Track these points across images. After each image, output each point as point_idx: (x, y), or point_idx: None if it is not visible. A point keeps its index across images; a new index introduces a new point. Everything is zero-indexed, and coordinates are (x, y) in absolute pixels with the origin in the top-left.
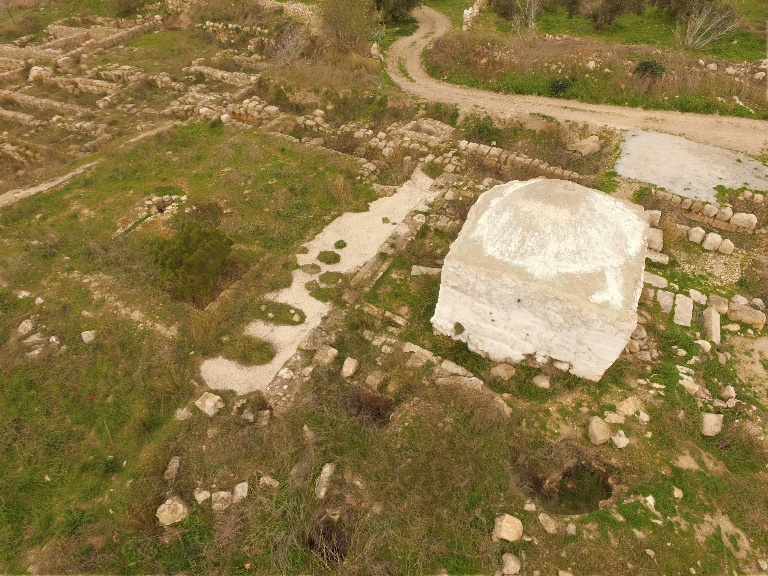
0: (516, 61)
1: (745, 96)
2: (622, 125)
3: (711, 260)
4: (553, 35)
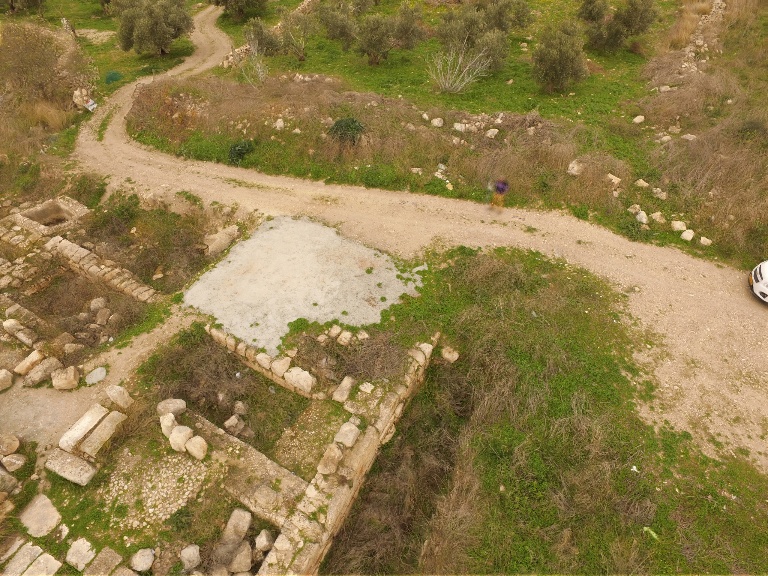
0: (207, 116)
1: (452, 164)
2: (276, 209)
3: (165, 472)
4: (305, 75)
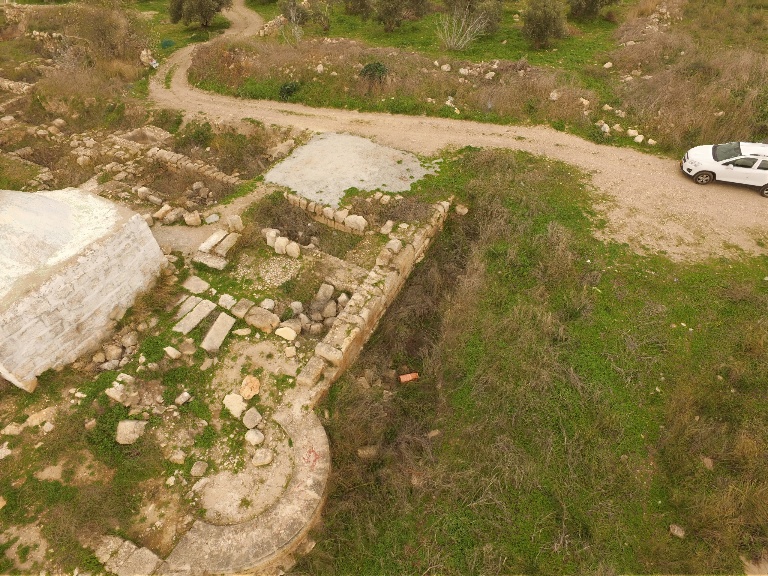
0: (259, 66)
1: (459, 96)
2: (323, 128)
3: (273, 264)
4: (332, 38)
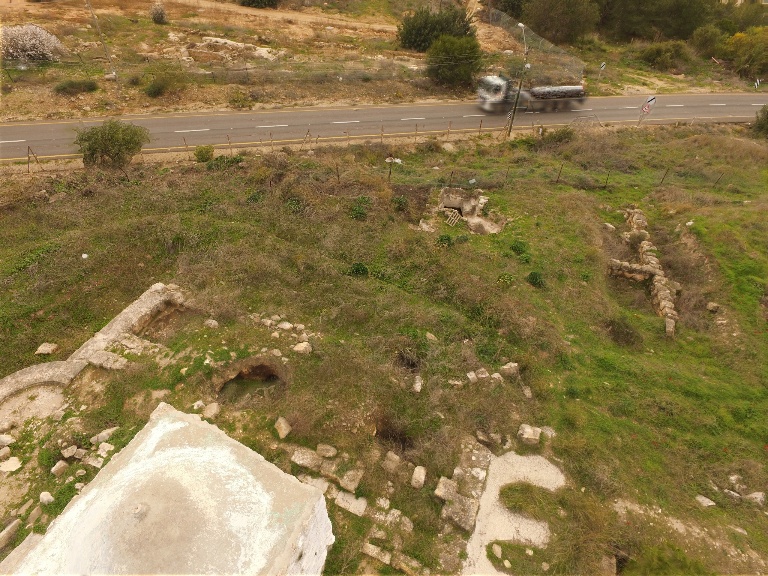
0: None
1: None
2: None
3: None
4: None
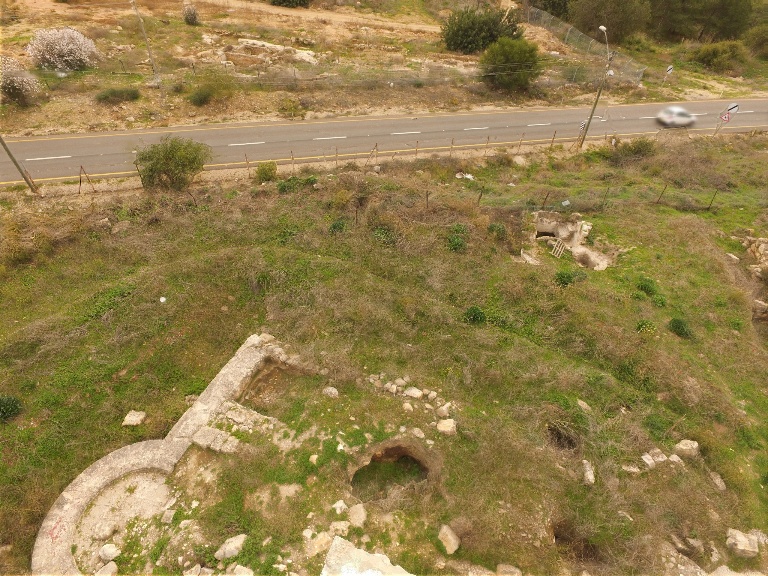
0: None
1: None
2: None
3: None
4: None
